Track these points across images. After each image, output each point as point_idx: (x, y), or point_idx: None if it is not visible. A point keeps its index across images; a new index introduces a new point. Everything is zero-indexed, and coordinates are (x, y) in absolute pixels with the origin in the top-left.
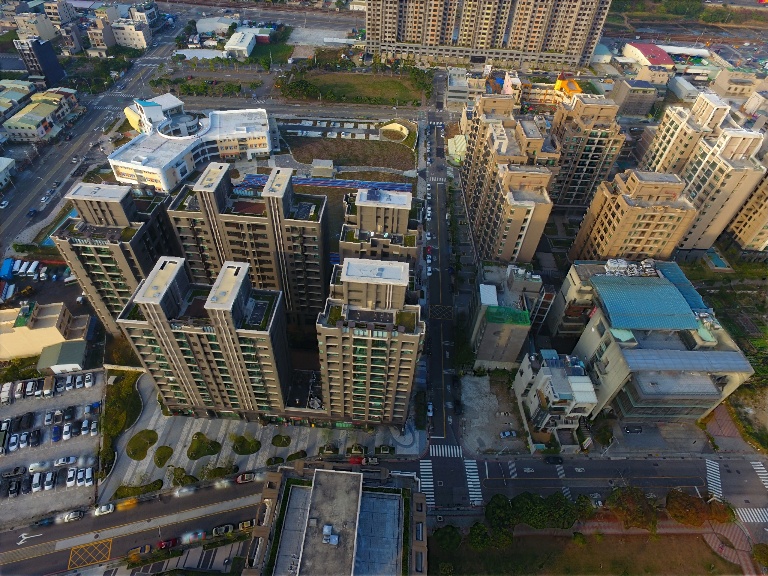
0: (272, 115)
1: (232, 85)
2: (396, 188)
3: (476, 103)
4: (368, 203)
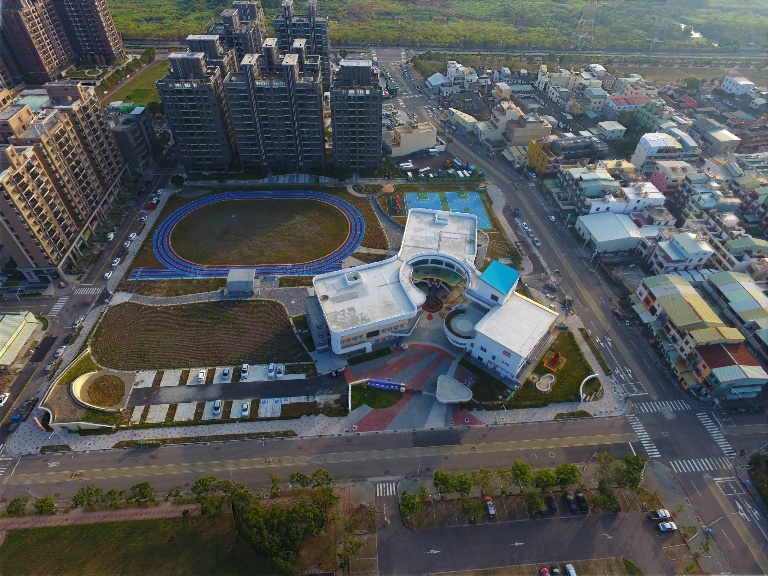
0: (344, 428)
1: (464, 501)
2: (153, 271)
3: (7, 177)
4: (197, 53)
